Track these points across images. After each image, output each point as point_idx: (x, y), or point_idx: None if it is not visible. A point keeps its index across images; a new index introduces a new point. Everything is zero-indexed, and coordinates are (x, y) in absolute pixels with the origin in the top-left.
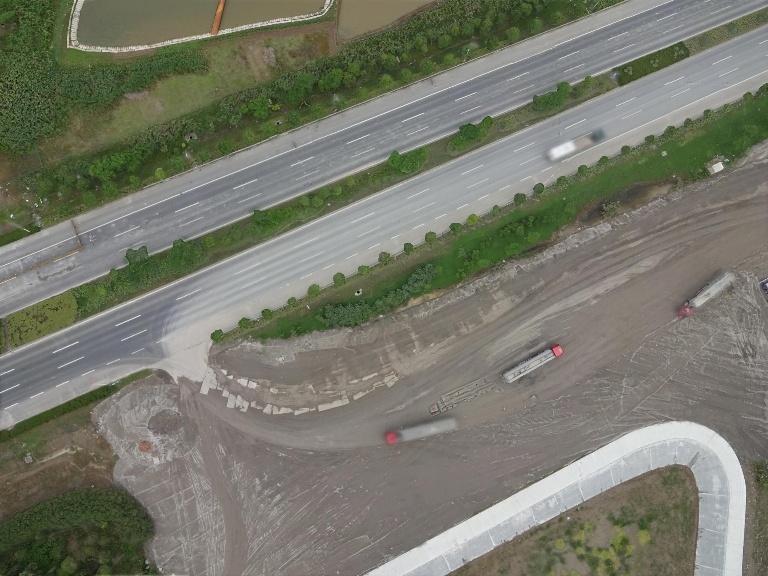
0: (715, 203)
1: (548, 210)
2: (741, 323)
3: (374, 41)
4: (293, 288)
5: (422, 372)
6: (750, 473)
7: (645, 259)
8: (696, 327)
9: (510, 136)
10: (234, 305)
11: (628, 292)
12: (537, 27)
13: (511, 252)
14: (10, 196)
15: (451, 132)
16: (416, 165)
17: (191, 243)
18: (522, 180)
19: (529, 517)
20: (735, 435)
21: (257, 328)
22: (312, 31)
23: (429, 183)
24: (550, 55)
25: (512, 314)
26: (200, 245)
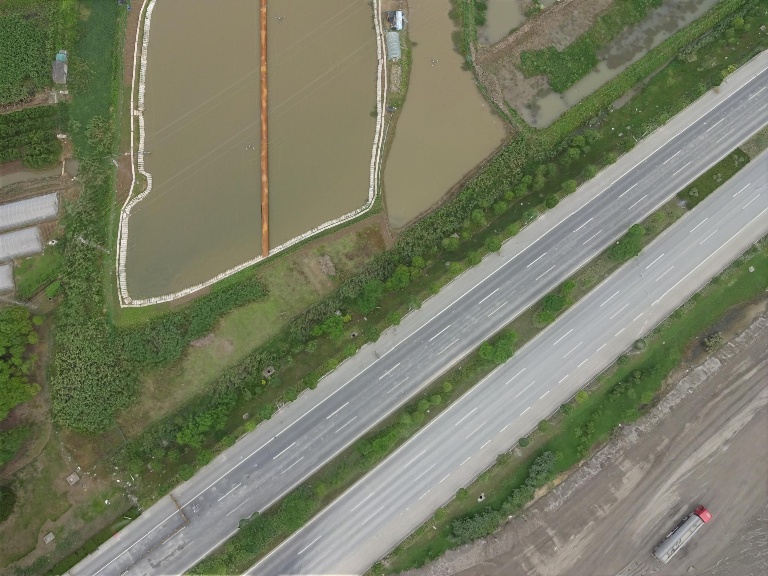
0: None
1: (651, 359)
2: None
3: (428, 223)
4: (414, 511)
5: (569, 570)
6: None
7: (764, 389)
8: None
9: (592, 291)
10: (358, 545)
11: (757, 429)
12: (593, 174)
13: (629, 420)
14: (100, 480)
15: (532, 302)
16: (510, 353)
17: (299, 490)
18: (617, 335)
19: None
20: None
21: (388, 564)
22: (363, 227)
23: (523, 362)
24: (609, 194)
25: (645, 483)
26: (309, 490)
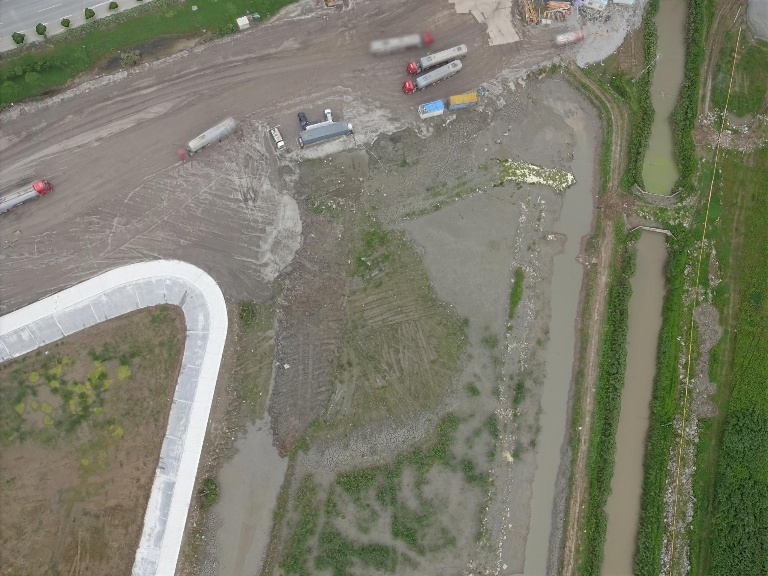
0: (237, 55)
1: (65, 57)
2: (246, 169)
3: None
4: None
5: None
6: (234, 311)
7: (156, 105)
8: (199, 171)
9: None
10: None
11: (133, 136)
12: None
13: (4, 90)
14: None
15: None
16: None
17: None
18: None
19: (0, 349)
20: (225, 275)
21: None
22: None
23: None
24: None
25: (7, 153)
26: None
